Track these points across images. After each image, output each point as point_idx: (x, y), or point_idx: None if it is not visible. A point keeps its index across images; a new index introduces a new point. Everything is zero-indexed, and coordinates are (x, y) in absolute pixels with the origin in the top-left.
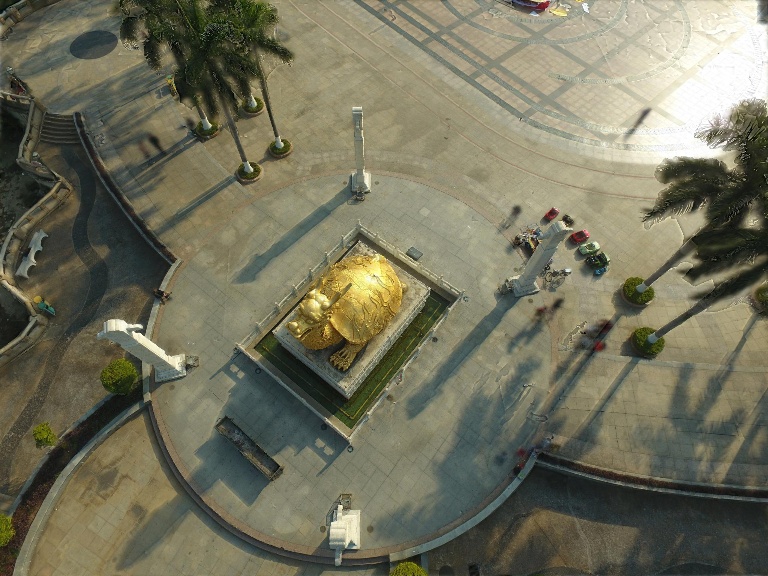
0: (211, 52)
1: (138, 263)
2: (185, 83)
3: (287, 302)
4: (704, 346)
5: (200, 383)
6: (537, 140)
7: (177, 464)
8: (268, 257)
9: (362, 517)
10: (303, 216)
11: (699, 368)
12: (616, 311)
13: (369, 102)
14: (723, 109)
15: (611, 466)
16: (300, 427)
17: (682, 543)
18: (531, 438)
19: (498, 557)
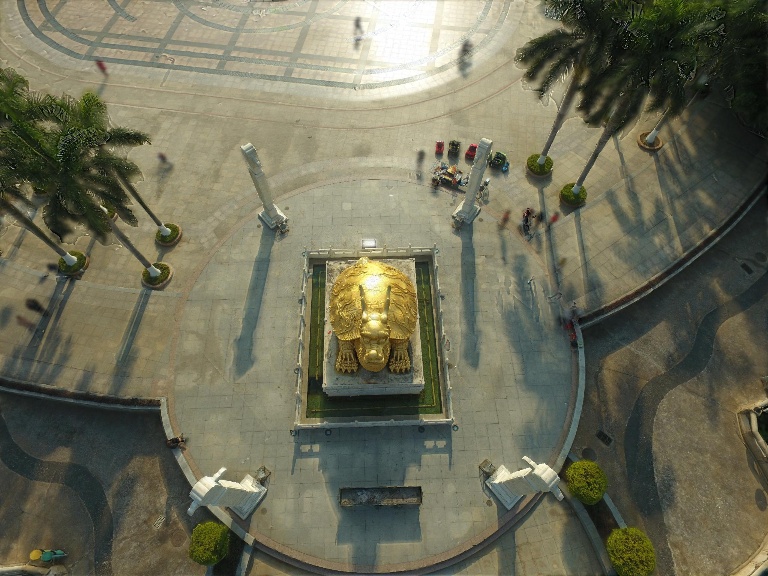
0: (71, 170)
1: (114, 437)
2: (60, 218)
3: (302, 358)
4: (604, 174)
5: (286, 485)
6: (381, 98)
7: (330, 567)
8: (248, 334)
9: (508, 468)
10: (247, 278)
11: (615, 190)
12: (537, 188)
13: (216, 145)
14: (484, 4)
15: (622, 293)
16: (403, 446)
17: (691, 309)
18: (563, 315)
19: (608, 413)
